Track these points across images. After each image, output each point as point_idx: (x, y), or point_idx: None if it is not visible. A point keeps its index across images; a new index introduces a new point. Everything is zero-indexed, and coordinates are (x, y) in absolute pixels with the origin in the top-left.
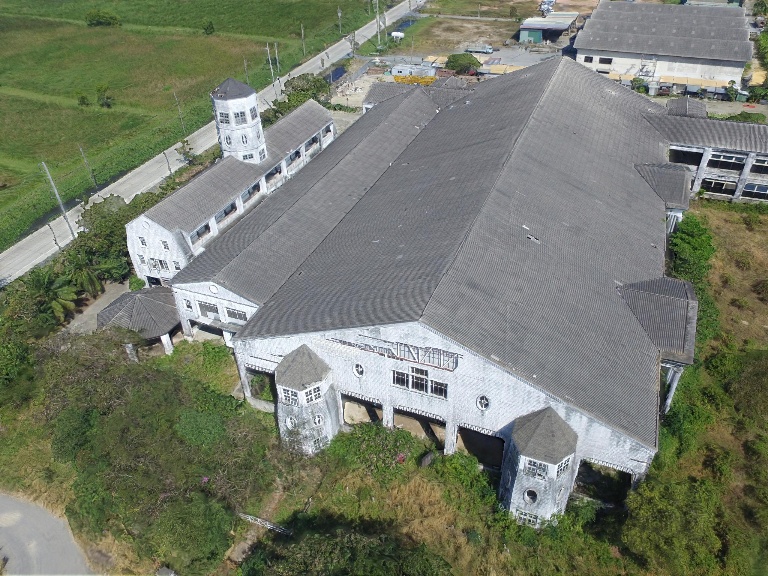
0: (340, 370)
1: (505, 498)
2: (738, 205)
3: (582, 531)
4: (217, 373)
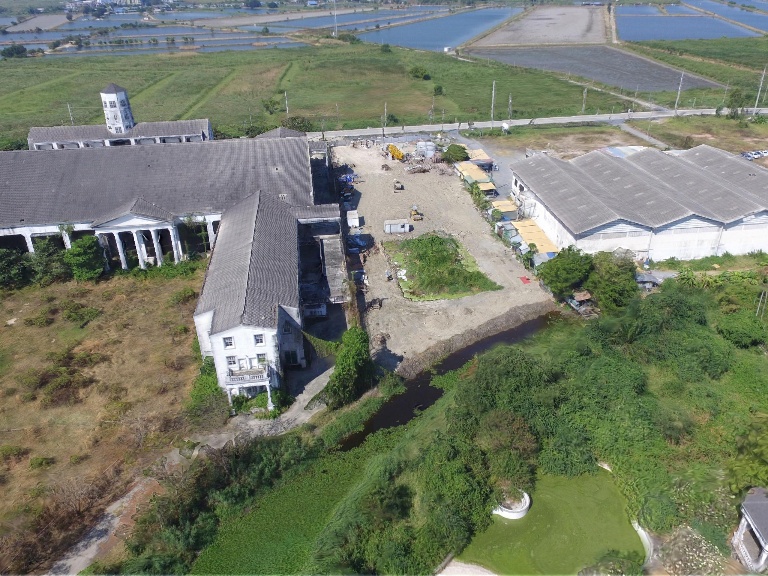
0: None
1: None
2: None
3: None
4: None
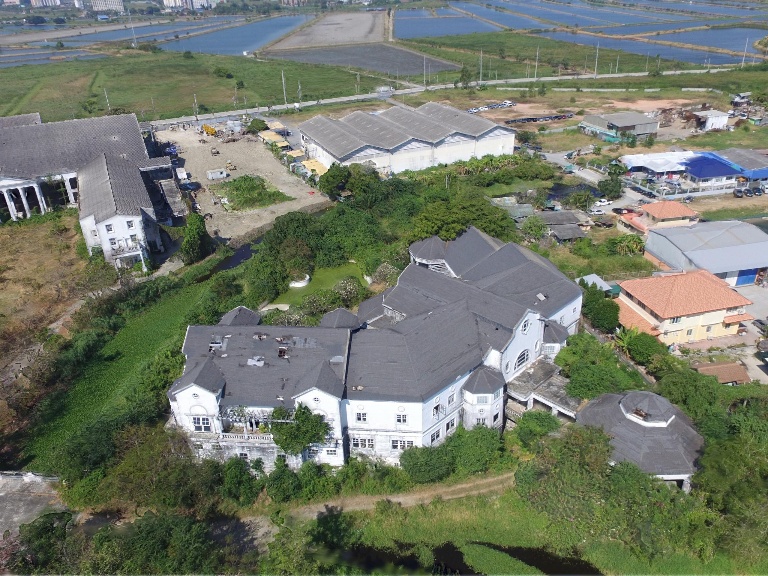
0: None
1: None
2: None
3: None
4: None
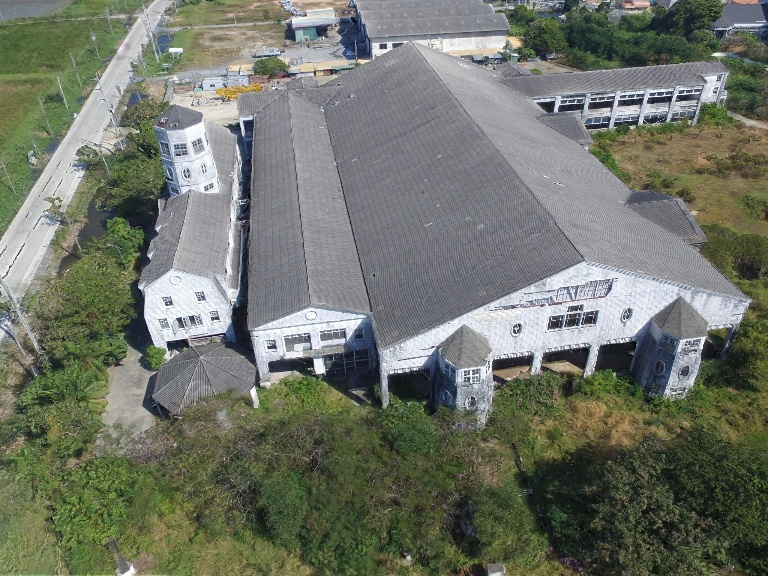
0: (497, 337)
1: (654, 386)
2: None
3: (705, 387)
4: (325, 403)
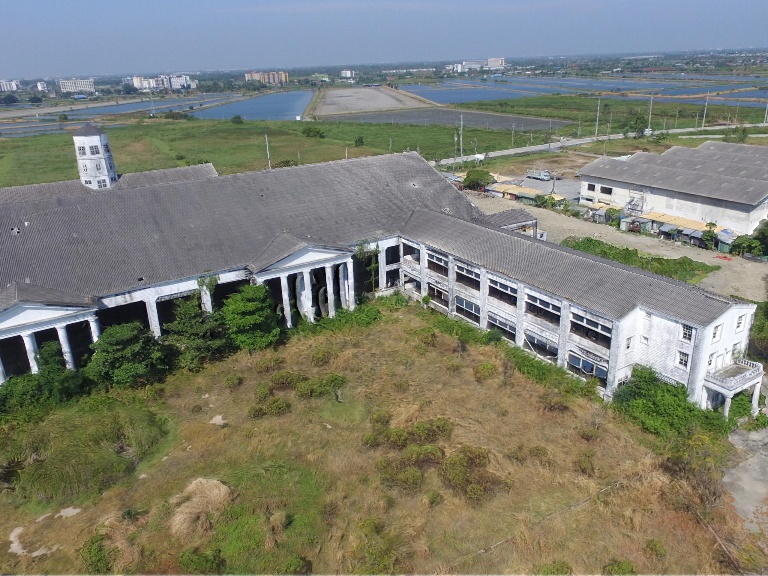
0: None
1: None
2: (447, 321)
3: None
4: None
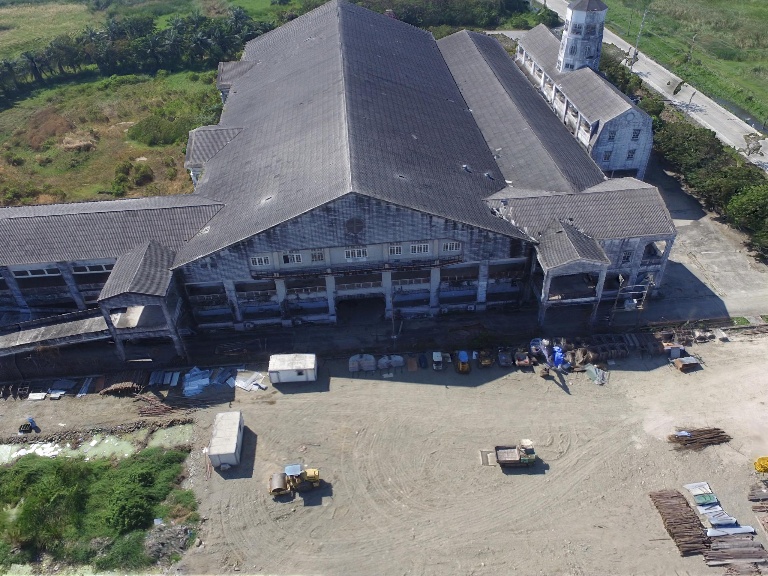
0: None
1: None
2: None
3: None
4: None
